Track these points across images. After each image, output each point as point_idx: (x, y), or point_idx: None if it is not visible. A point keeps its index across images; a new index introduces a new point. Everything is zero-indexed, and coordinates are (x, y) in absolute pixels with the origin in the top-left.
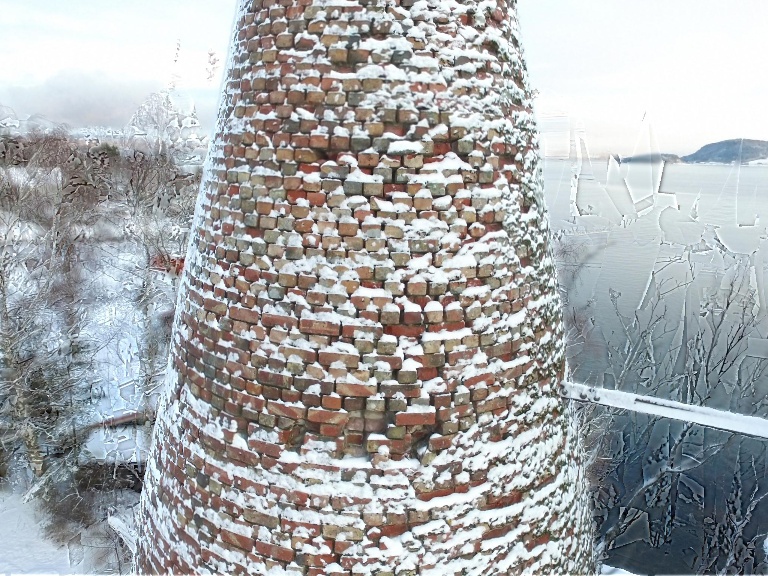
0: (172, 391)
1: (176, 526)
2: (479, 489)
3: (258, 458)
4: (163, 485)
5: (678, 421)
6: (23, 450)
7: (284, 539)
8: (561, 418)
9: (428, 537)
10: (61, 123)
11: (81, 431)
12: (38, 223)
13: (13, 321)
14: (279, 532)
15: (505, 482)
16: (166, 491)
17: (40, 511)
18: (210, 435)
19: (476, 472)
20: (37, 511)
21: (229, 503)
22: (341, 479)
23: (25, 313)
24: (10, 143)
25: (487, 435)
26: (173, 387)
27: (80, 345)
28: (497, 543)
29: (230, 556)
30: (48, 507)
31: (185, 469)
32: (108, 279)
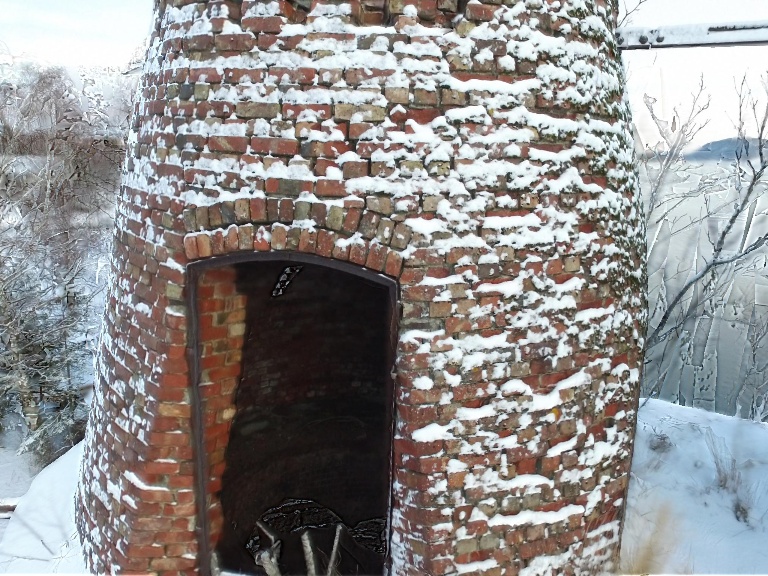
0: (152, 32)
1: (155, 164)
2: (526, 83)
3: (254, 39)
4: (141, 136)
5: (688, 381)
6: (16, 390)
7: (286, 128)
8: (617, 66)
9: (465, 125)
10: (56, 62)
11: (76, 372)
12: (31, 160)
13: (7, 268)
14: (280, 121)
15: (557, 87)
16: (144, 139)
17: (35, 466)
18: (195, 34)
19: (523, 61)
20: (32, 466)
21: (218, 103)
22: (357, 47)
23: (18, 253)
24: (4, 85)
25: (536, 22)
26: (153, 26)
27: (75, 290)
28: (548, 156)
29: (219, 165)
30: (43, 460)
31: (166, 94)
32: (103, 216)
